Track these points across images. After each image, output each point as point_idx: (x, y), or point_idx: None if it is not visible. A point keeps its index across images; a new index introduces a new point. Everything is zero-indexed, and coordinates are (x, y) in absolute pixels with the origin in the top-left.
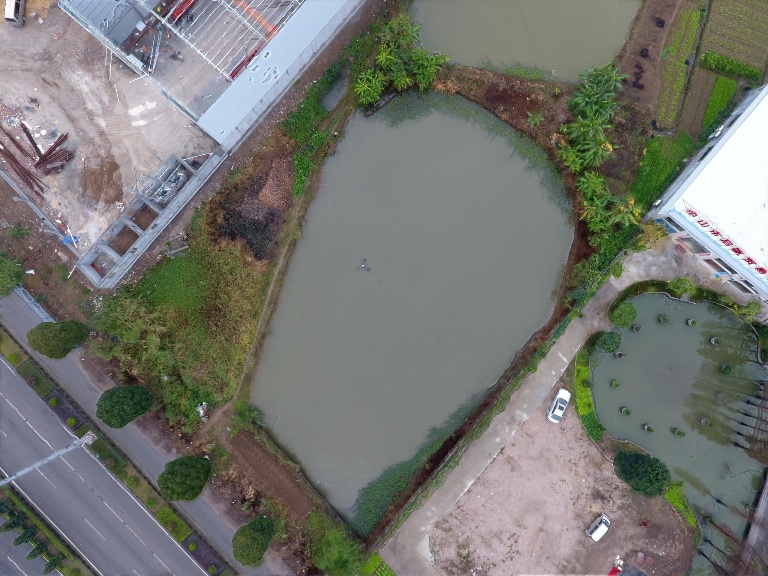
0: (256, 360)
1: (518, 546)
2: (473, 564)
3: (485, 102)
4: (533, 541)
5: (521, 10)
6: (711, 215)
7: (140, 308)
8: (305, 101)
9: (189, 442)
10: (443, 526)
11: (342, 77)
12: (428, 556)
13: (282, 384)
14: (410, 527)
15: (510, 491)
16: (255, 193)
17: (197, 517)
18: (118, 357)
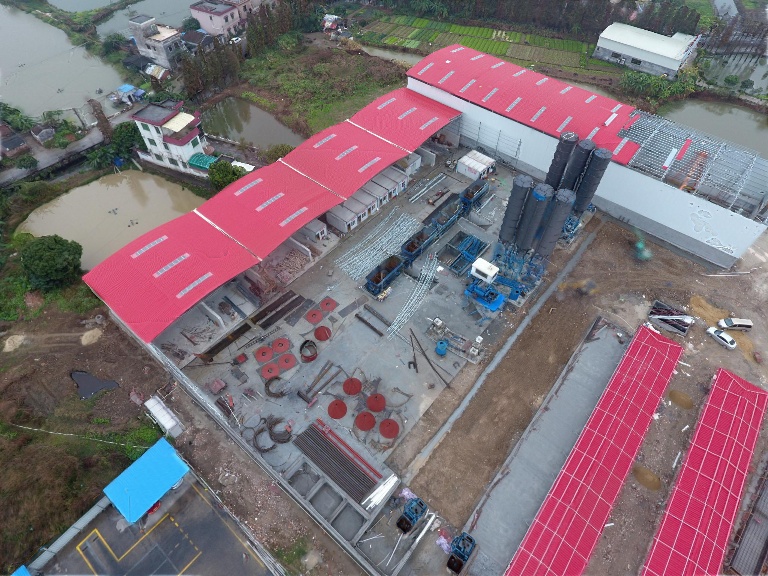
0: None
1: None
2: None
3: None
4: None
5: None
6: (677, 51)
7: None
8: None
9: None
10: None
11: None
12: None
13: None
14: None
15: None
16: None
17: None
18: None
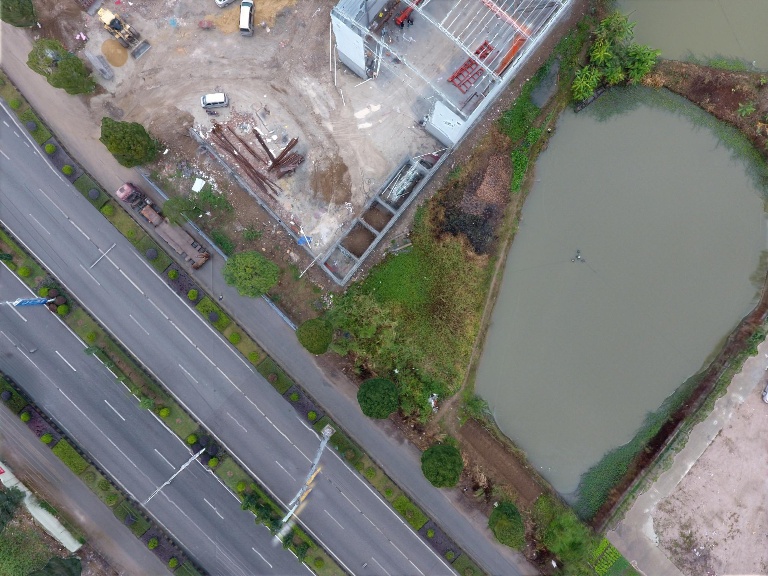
0: (480, 352)
1: (739, 525)
2: (696, 544)
3: (691, 94)
4: (753, 520)
5: (721, 4)
6: None
7: (374, 304)
8: (518, 99)
9: (422, 432)
10: (666, 508)
11: (551, 75)
12: (653, 537)
13: (501, 374)
14: (634, 509)
15: (729, 472)
16: (473, 190)
17: (430, 505)
18: (353, 352)
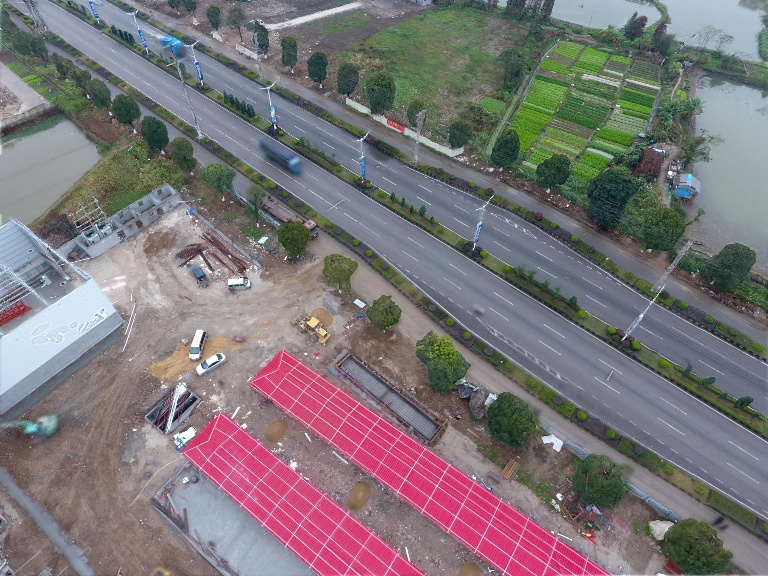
0: None
1: None
2: None
3: None
4: None
5: None
6: None
7: None
8: None
9: None
10: (8, 115)
11: None
12: (24, 106)
13: None
14: None
15: None
16: None
17: None
18: None
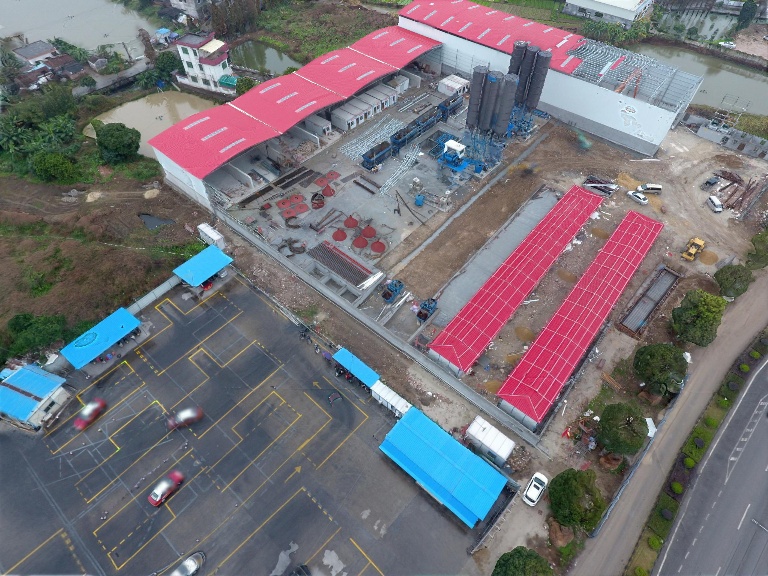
0: None
1: None
2: None
3: None
4: None
5: None
6: (633, 4)
7: None
8: None
9: None
10: None
11: None
12: None
13: None
14: None
15: None
16: None
17: None
18: None
